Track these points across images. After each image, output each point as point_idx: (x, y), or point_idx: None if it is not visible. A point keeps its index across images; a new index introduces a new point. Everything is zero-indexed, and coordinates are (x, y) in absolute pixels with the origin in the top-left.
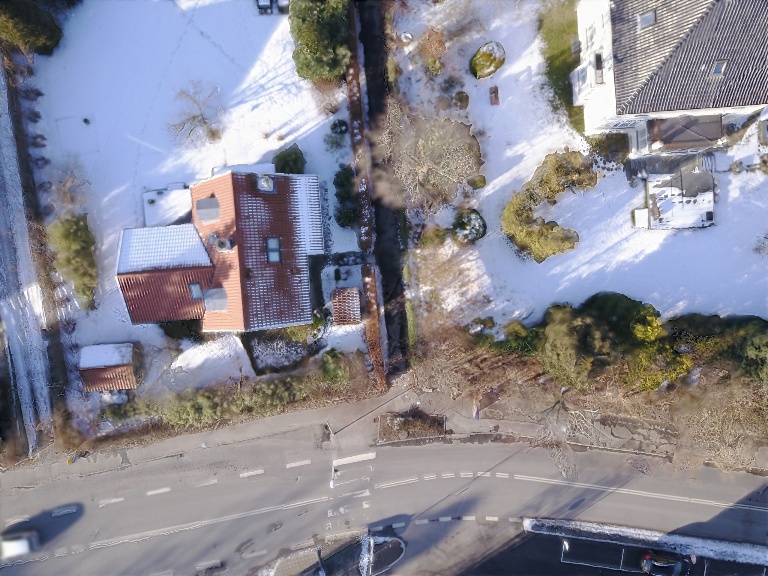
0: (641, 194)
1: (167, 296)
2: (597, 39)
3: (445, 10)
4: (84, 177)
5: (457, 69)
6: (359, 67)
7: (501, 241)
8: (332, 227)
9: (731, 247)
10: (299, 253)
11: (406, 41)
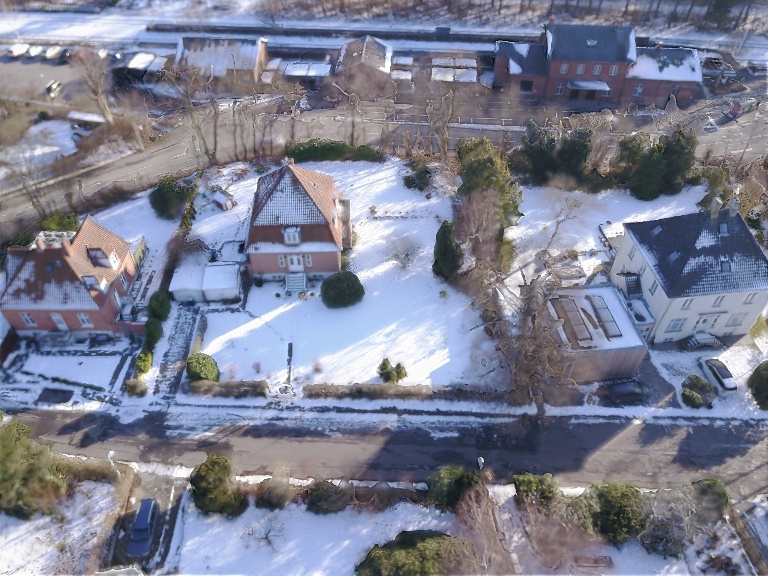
0: None
1: None
2: None
3: None
4: None
5: None
6: None
7: None
8: None
9: (583, 218)
10: None
11: None
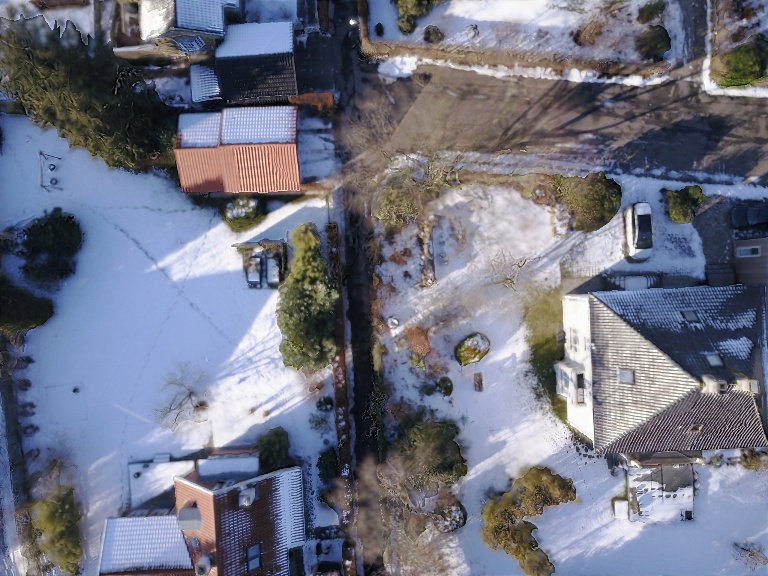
0: (622, 483)
1: None
2: (580, 352)
3: (432, 295)
4: (72, 444)
5: (442, 355)
6: (346, 344)
7: None
8: (315, 501)
9: (710, 540)
10: (280, 550)
11: (392, 327)
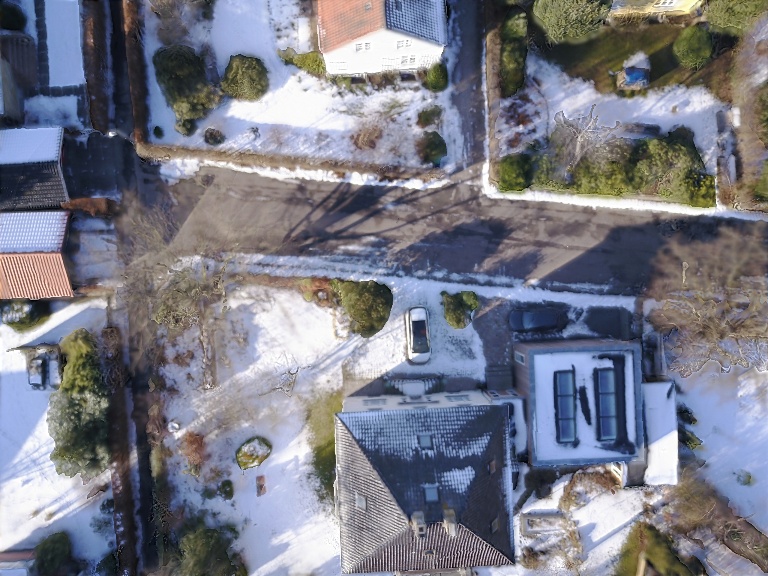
0: None
1: None
2: None
3: (215, 397)
4: None
5: (224, 458)
6: (131, 445)
7: None
8: None
9: None
10: None
11: (173, 431)
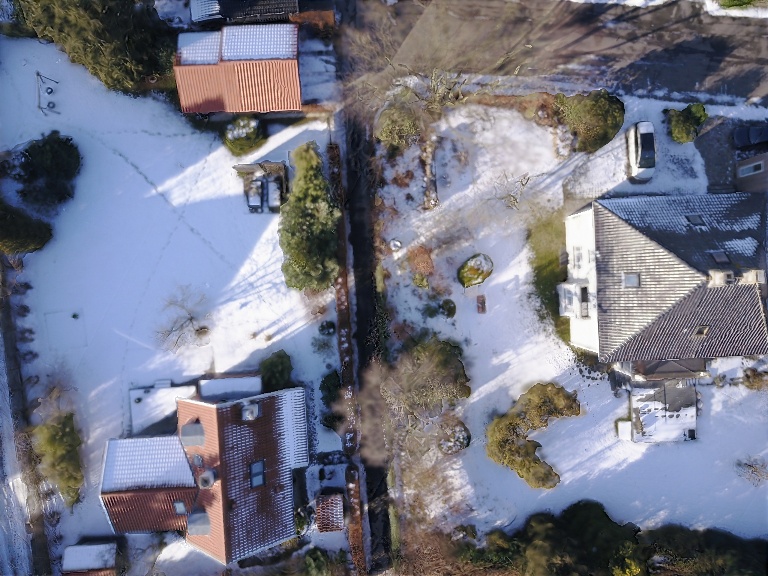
0: (625, 404)
1: (151, 511)
2: (583, 268)
3: (434, 217)
4: (71, 371)
5: (445, 277)
6: (348, 268)
7: (485, 448)
8: (318, 427)
9: (713, 460)
10: (283, 469)
11: (395, 249)
